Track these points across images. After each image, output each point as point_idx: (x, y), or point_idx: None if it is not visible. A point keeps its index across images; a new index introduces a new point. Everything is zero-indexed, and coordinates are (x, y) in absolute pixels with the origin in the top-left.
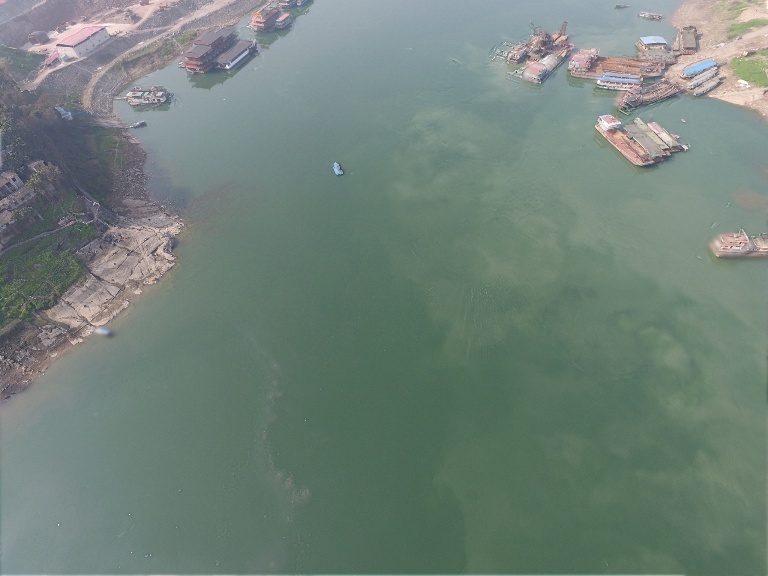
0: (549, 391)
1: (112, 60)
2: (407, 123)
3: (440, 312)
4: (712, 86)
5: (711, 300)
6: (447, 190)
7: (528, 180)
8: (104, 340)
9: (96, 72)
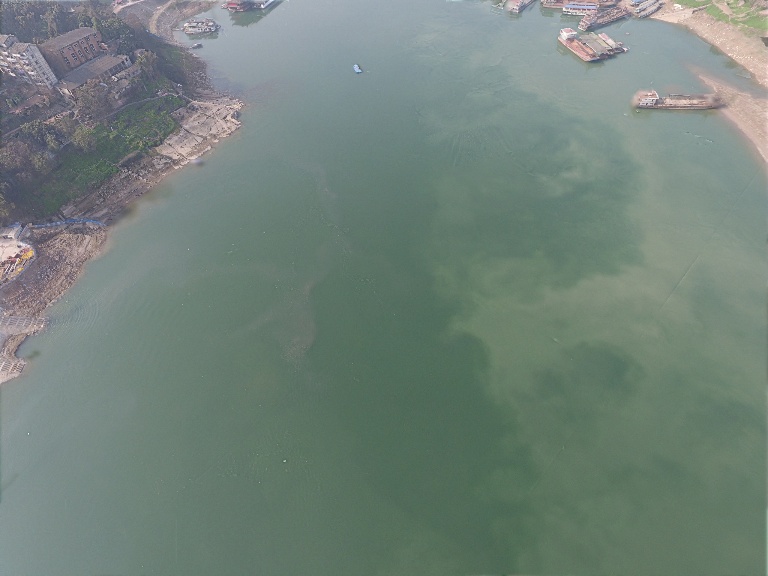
0: (510, 185)
1: (168, 2)
2: (410, 40)
3: (435, 145)
4: (653, 10)
5: (629, 137)
6: (441, 82)
7: (503, 71)
8: (197, 167)
9: (156, 10)
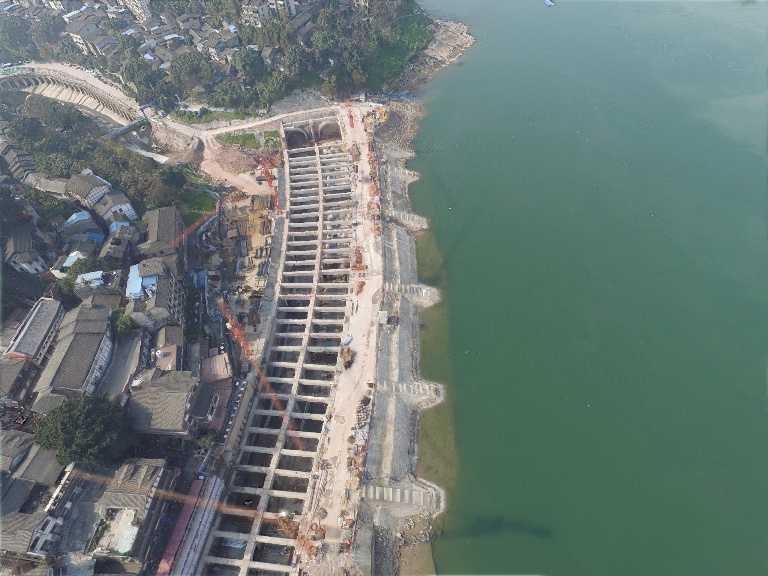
0: (721, 76)
1: None
2: None
3: (650, 50)
4: None
5: None
6: (624, 12)
7: (678, 3)
8: None
9: None
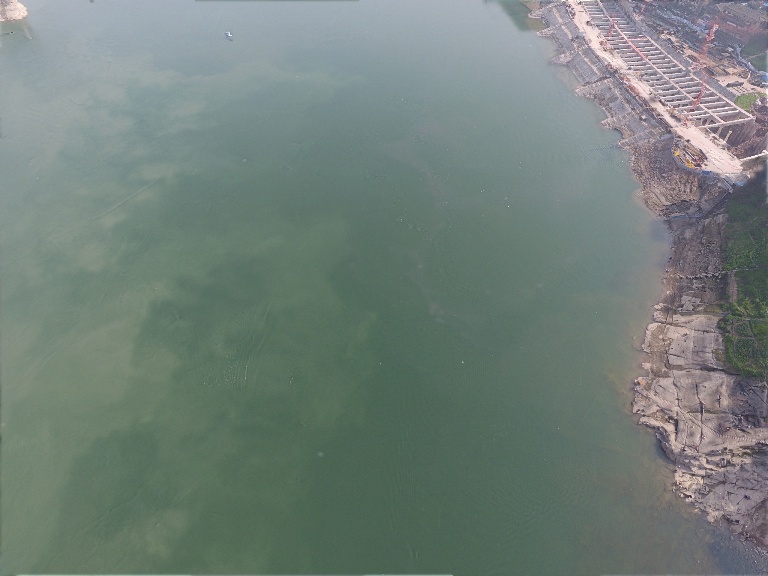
0: (212, 292)
1: None
2: None
3: (286, 346)
4: None
5: None
6: None
7: None
8: None
9: None
